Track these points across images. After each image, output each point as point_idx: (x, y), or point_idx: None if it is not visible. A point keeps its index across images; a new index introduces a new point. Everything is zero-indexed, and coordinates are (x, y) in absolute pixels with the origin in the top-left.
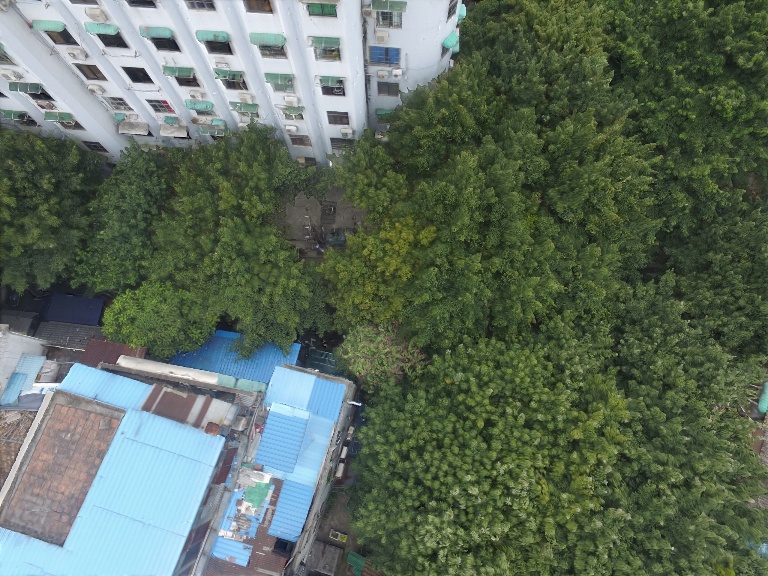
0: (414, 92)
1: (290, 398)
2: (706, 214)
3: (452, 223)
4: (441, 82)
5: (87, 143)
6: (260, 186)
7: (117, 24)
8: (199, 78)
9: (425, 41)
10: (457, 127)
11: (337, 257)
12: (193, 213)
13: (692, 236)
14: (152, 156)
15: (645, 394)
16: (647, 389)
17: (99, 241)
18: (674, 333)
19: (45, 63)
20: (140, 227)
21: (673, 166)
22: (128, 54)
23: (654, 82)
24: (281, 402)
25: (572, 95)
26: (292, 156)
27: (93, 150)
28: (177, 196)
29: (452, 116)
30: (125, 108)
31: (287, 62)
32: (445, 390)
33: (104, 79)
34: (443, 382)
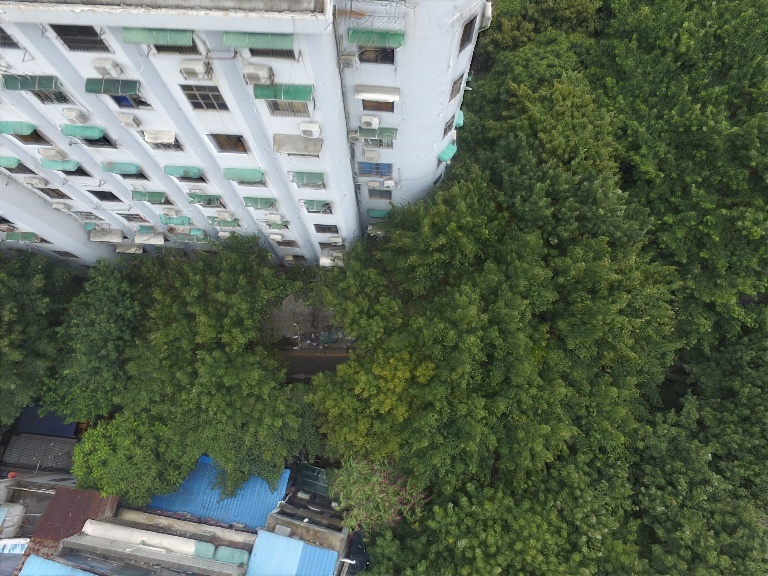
0: (408, 209)
1: (275, 570)
2: (730, 332)
3: (452, 364)
4: (437, 206)
5: (56, 251)
6: (241, 315)
7: (76, 159)
8: (172, 199)
9: (419, 158)
10: (456, 254)
11: (327, 385)
12: (169, 342)
13: (714, 352)
14: (126, 269)
15: (672, 565)
16: (674, 559)
17: (68, 368)
18: (701, 484)
19: (1, 193)
20: (111, 357)
21: (694, 287)
22: (92, 182)
23: (670, 189)
24: (265, 575)
25: (582, 215)
26: (279, 254)
27: (64, 256)
28: (152, 319)
29: (450, 241)
30: (96, 217)
31: (267, 189)
32: (448, 548)
33: (69, 198)
34: (445, 540)
